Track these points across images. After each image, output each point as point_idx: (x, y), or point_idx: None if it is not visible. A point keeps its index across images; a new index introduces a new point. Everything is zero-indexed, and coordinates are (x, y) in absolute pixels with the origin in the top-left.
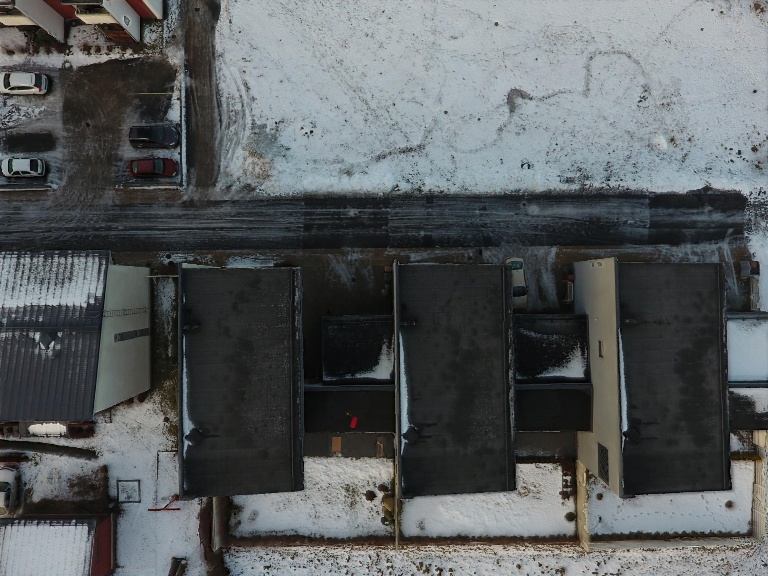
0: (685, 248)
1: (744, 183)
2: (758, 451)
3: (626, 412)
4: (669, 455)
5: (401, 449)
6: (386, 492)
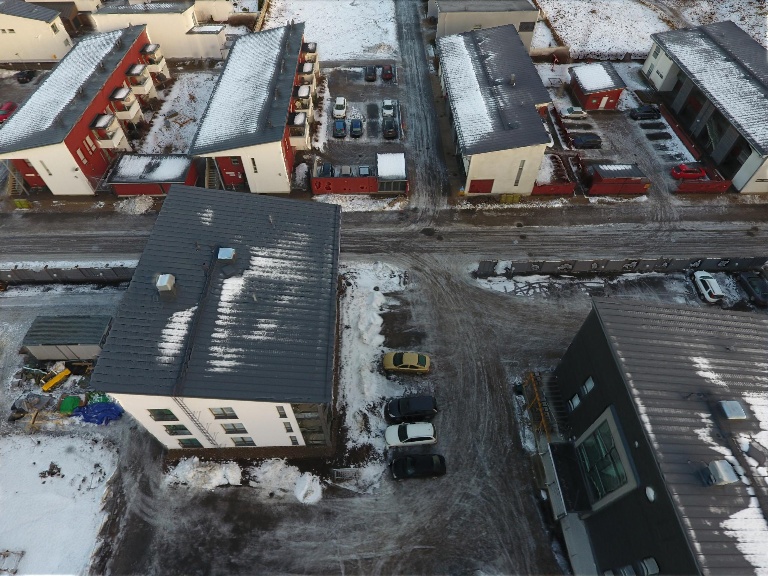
0: None
1: None
2: None
3: None
4: None
5: None
6: None
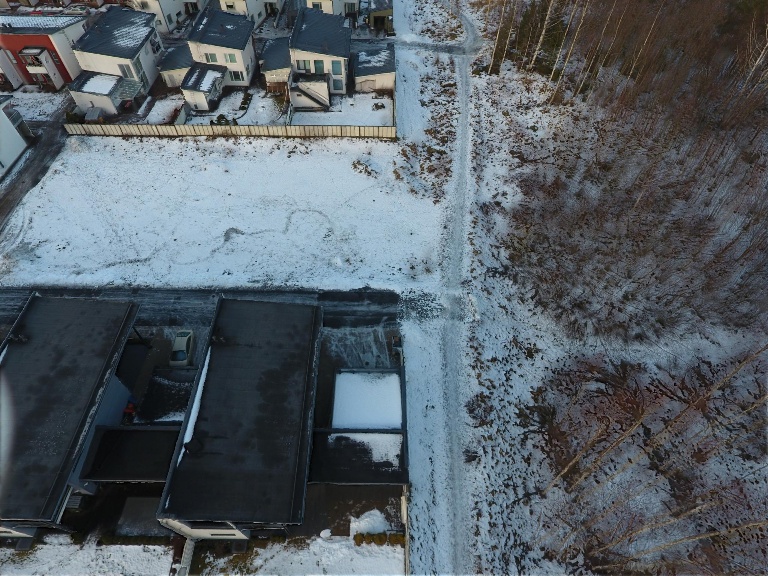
0: (345, 330)
1: (396, 285)
2: (405, 532)
3: (194, 423)
4: (232, 474)
5: None
6: None
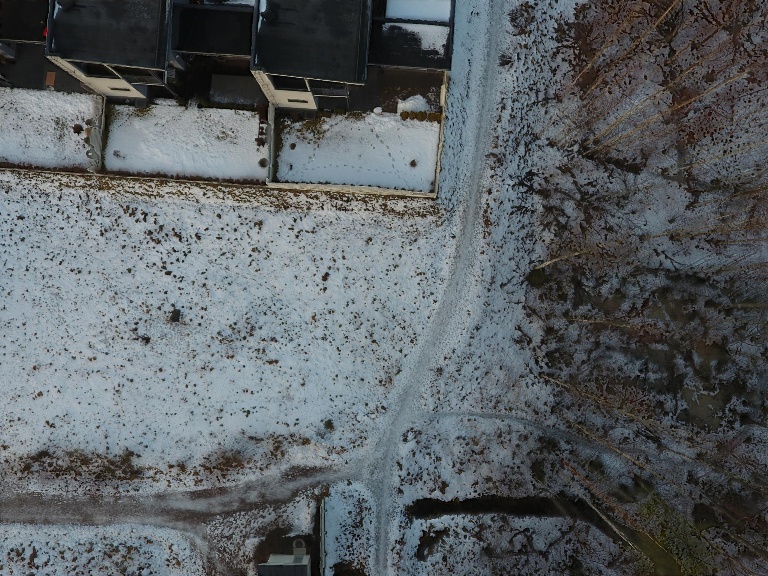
0: None
1: None
2: (442, 112)
3: None
4: (305, 42)
5: (54, 13)
6: (93, 127)
